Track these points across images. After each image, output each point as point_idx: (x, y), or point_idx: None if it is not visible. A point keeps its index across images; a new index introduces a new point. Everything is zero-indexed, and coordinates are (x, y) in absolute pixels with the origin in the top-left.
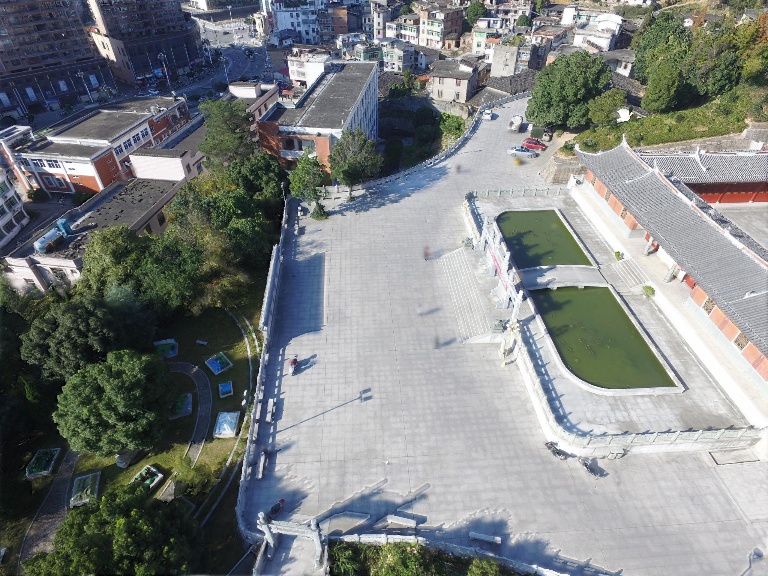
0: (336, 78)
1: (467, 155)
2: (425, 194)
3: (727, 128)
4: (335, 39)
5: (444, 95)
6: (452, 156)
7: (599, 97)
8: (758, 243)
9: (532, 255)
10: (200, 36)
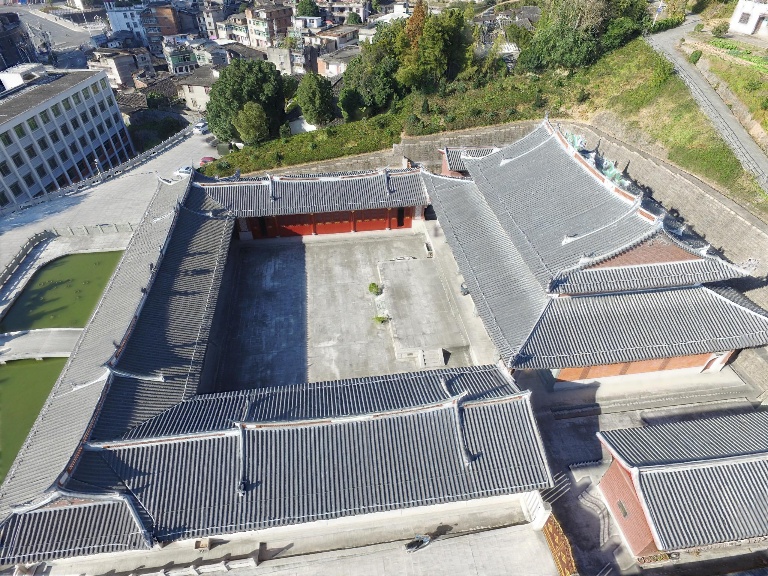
0: (33, 91)
1: (129, 179)
2: (22, 232)
3: (377, 143)
4: (161, 41)
5: (198, 104)
6: (110, 180)
7: (240, 112)
8: (307, 286)
9: (34, 314)
10: (27, 39)
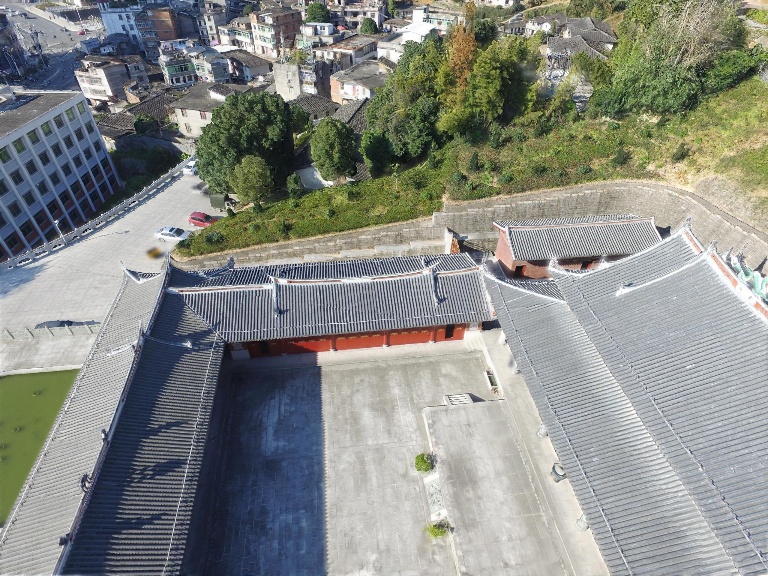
0: None
1: (99, 241)
2: None
3: (413, 210)
4: (158, 46)
5: (193, 130)
6: (76, 243)
7: (237, 166)
8: (325, 450)
9: None
10: (15, 42)
